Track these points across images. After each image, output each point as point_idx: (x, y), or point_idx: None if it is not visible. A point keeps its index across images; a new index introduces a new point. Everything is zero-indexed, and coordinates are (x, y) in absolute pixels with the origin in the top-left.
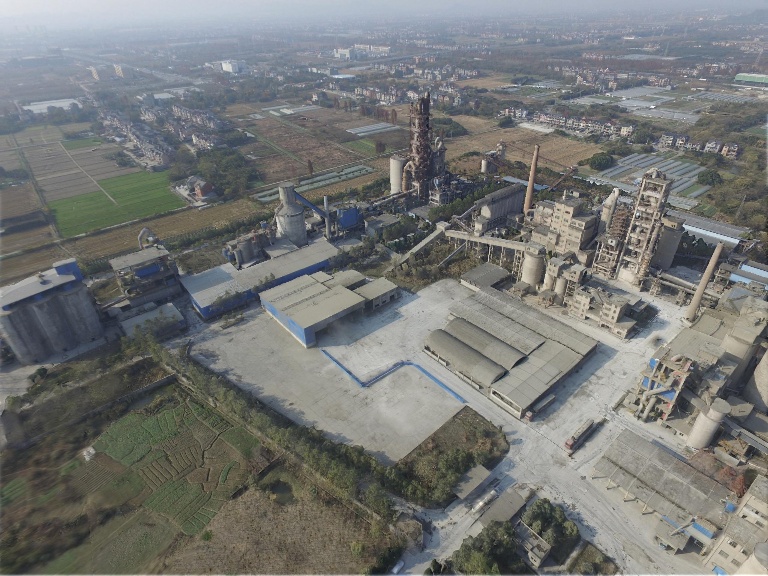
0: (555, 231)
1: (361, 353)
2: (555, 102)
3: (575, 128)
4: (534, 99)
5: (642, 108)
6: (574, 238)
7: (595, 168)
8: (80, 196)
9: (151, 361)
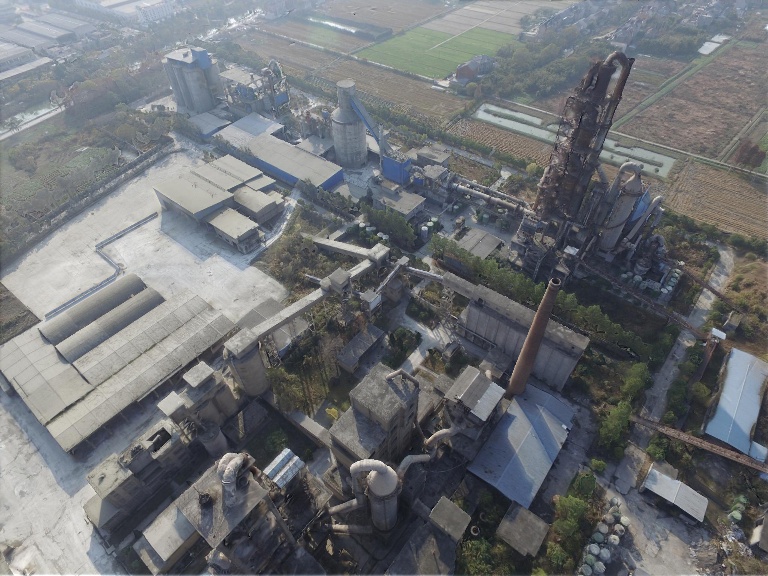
0: None
1: (146, 239)
2: None
3: None
4: None
5: None
6: None
7: None
8: (438, 32)
9: (163, 140)
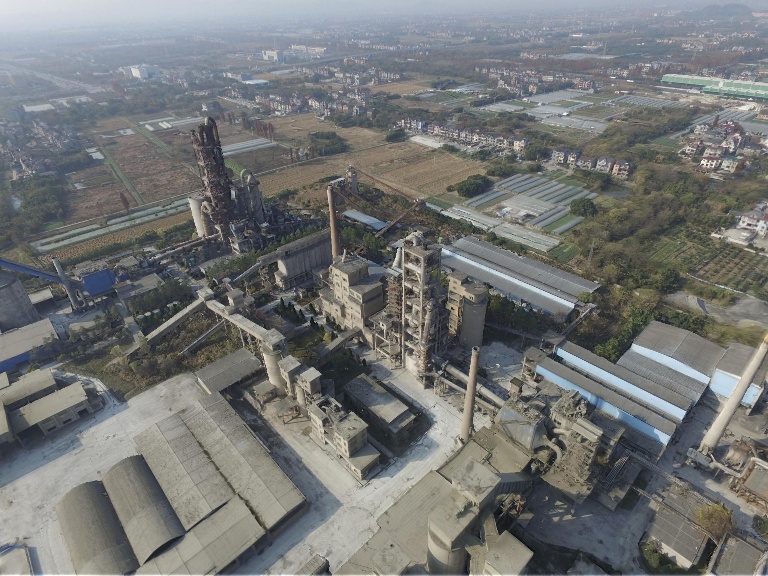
0: (339, 301)
1: None
2: (463, 110)
3: (468, 142)
4: (444, 106)
5: (554, 115)
6: (355, 312)
7: (463, 195)
8: None
9: None
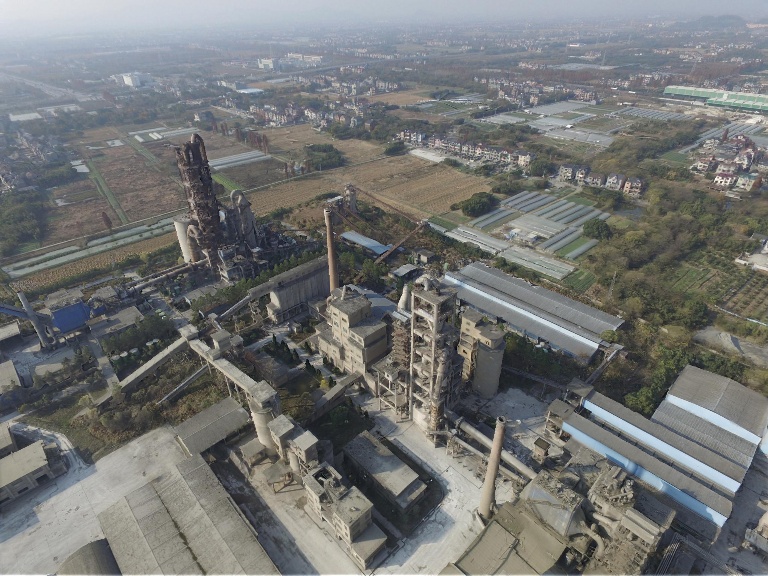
0: (338, 341)
1: None
2: (464, 121)
3: (470, 156)
4: (444, 117)
5: (557, 128)
6: (356, 356)
7: (468, 214)
8: None
9: None
